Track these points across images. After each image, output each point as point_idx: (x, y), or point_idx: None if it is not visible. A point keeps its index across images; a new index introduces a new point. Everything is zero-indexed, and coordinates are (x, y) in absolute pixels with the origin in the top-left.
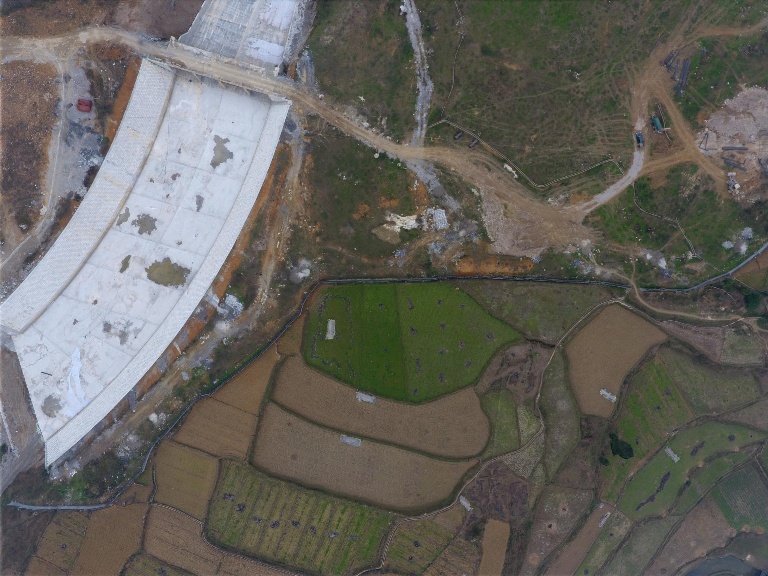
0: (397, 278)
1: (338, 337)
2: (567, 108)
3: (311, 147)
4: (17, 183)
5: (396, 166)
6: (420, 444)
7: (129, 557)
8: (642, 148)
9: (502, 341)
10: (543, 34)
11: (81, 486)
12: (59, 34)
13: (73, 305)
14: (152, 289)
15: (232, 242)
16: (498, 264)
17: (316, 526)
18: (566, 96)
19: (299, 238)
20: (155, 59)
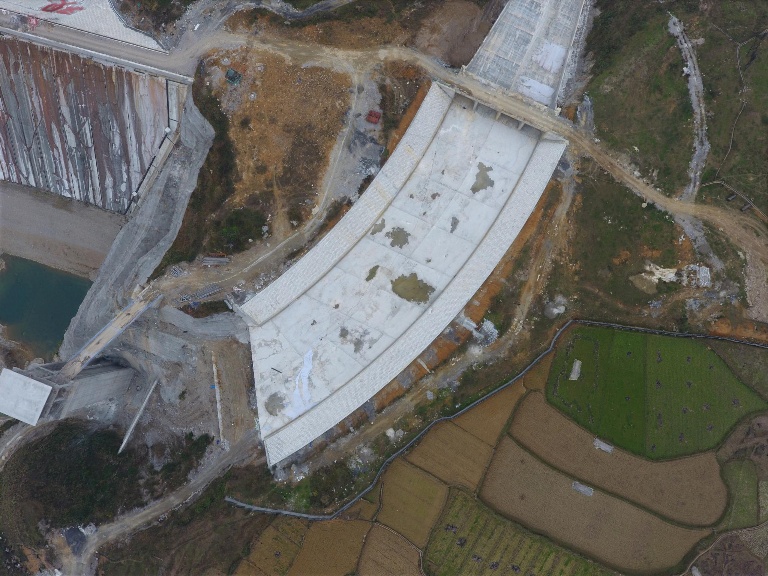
0: (649, 328)
1: (582, 379)
2: None
3: (581, 187)
4: (295, 180)
5: (663, 218)
6: (653, 504)
7: None
8: None
9: (748, 409)
10: None
11: (306, 492)
12: (360, 48)
13: (315, 306)
14: (394, 302)
15: (491, 268)
16: (756, 330)
17: (536, 574)
18: None
19: (559, 274)
20: (444, 84)
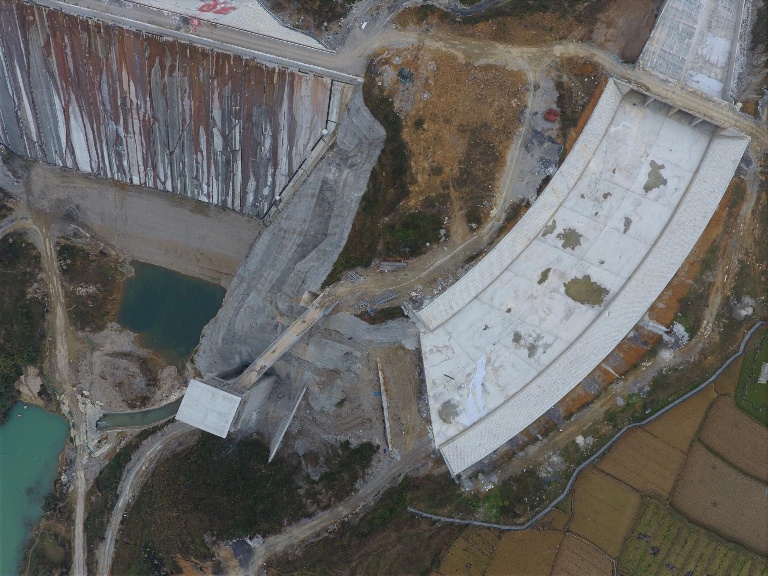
0: None
1: None
2: None
3: (765, 185)
4: (472, 182)
5: None
6: None
7: None
8: None
9: None
10: None
11: (496, 502)
12: (535, 44)
13: (486, 310)
14: (568, 305)
15: (674, 269)
16: None
17: None
18: None
19: (746, 274)
20: (621, 80)
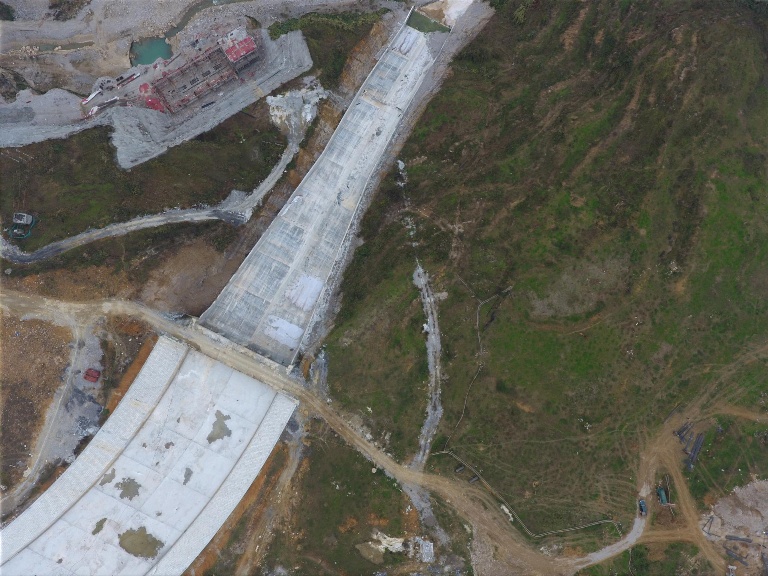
0: None
1: None
2: (574, 459)
3: (310, 451)
4: (7, 440)
5: (392, 485)
6: None
7: None
8: (644, 516)
9: None
10: (560, 378)
11: None
12: (83, 301)
13: (37, 560)
14: (121, 557)
15: (211, 535)
16: None
17: None
18: (574, 447)
19: (280, 544)
20: (172, 338)
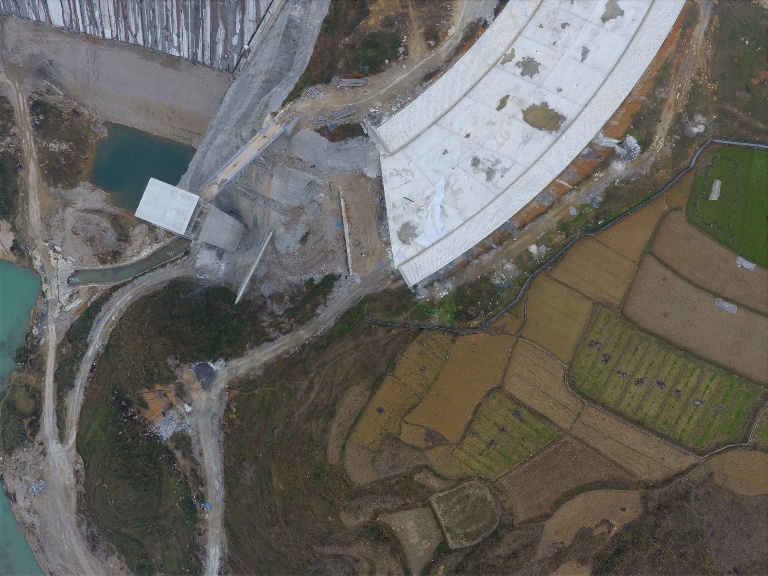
0: None
1: (722, 199)
2: None
3: (718, 8)
4: (431, 2)
5: None
6: None
7: (488, 390)
8: None
9: None
10: None
11: (450, 308)
12: None
13: (446, 135)
14: (526, 131)
15: (628, 89)
16: None
17: (682, 390)
18: None
19: (698, 93)
20: None
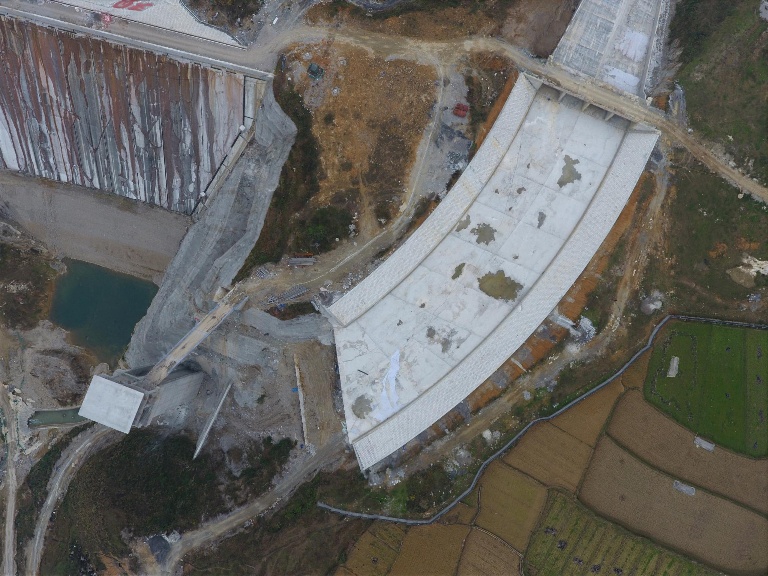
0: (748, 323)
1: (680, 376)
2: None
3: (675, 179)
4: (381, 177)
5: (760, 209)
6: (756, 503)
7: None
8: None
9: None
10: None
11: (403, 497)
12: (445, 40)
13: (400, 305)
14: (482, 300)
15: (584, 264)
16: None
17: None
18: None
19: (655, 269)
20: (532, 74)
